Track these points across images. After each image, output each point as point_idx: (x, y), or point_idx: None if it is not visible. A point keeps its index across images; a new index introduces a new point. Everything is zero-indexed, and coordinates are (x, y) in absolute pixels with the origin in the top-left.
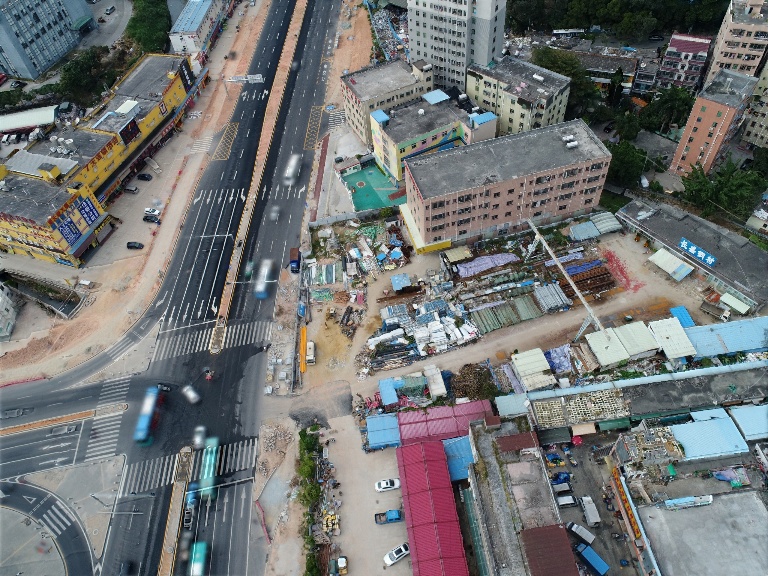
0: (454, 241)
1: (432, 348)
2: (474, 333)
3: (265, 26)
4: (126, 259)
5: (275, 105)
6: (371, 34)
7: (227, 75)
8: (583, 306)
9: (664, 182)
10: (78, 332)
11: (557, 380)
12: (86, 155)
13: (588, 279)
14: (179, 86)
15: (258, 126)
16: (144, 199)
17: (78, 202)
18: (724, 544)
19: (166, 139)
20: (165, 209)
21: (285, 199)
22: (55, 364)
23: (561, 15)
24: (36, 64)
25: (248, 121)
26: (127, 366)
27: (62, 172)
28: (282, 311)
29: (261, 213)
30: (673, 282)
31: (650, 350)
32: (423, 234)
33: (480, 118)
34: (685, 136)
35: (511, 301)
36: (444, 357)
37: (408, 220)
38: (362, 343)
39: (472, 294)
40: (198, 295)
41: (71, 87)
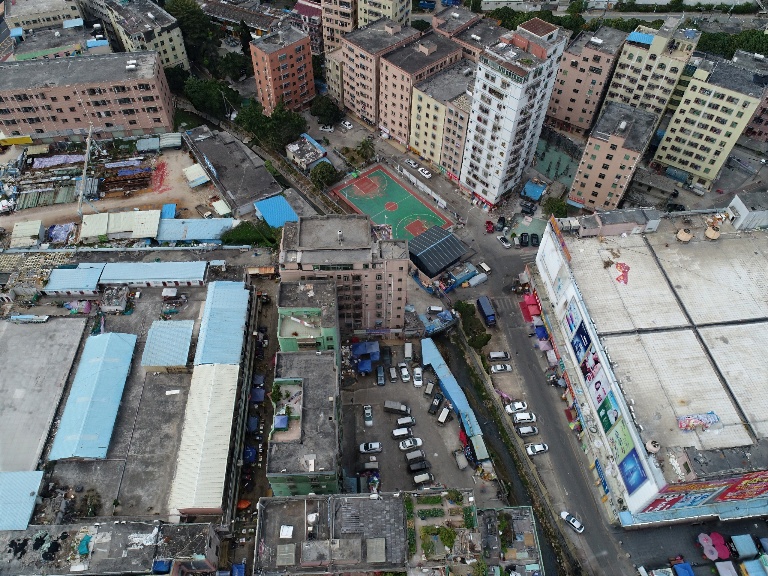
0: (35, 138)
1: None
2: (6, 207)
3: None
4: None
5: None
6: None
7: None
8: (111, 199)
9: None
10: None
11: (39, 244)
12: None
13: (129, 180)
14: None
15: None
16: None
17: None
18: (33, 347)
19: None
20: None
21: None
22: None
23: None
24: None
25: None
26: None
27: None
28: None
29: None
30: (194, 190)
31: (127, 231)
32: None
33: (93, 43)
34: (256, 79)
35: (57, 189)
36: None
37: None
38: None
39: (31, 181)
40: None
41: None
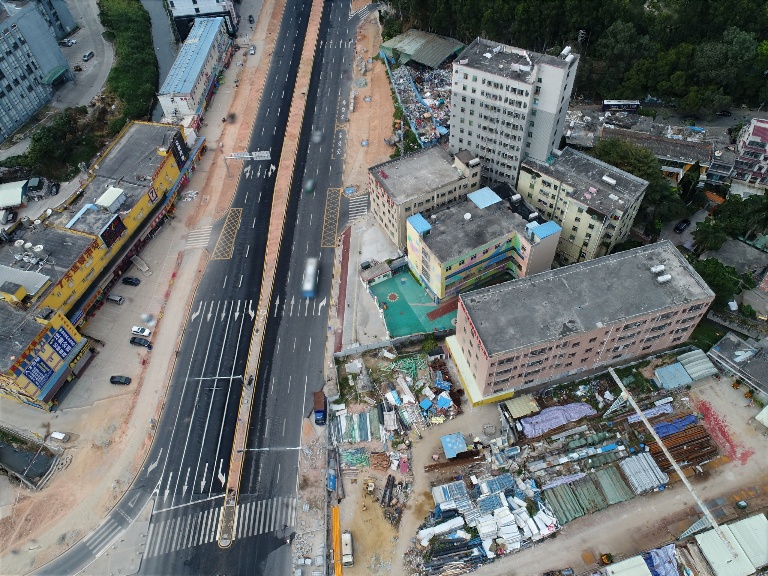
0: (517, 390)
1: (501, 547)
2: (553, 526)
3: (268, 80)
4: (109, 399)
5: (284, 186)
6: (391, 96)
7: (226, 144)
8: (682, 483)
9: (754, 303)
10: (49, 510)
11: None
12: (59, 265)
13: (684, 444)
14: (171, 165)
15: (265, 213)
16: (131, 312)
17: (49, 335)
18: None
19: (156, 229)
20: (157, 327)
21: (303, 316)
22: (19, 561)
23: (614, 85)
24: (0, 127)
25: (253, 206)
26: (112, 565)
27: (29, 292)
28: (307, 483)
29: (274, 336)
30: None
31: None
32: (482, 387)
33: (541, 230)
34: None
35: (593, 475)
36: (517, 559)
37: (459, 360)
38: (411, 534)
39: (543, 463)
40: (201, 456)
41: (42, 160)
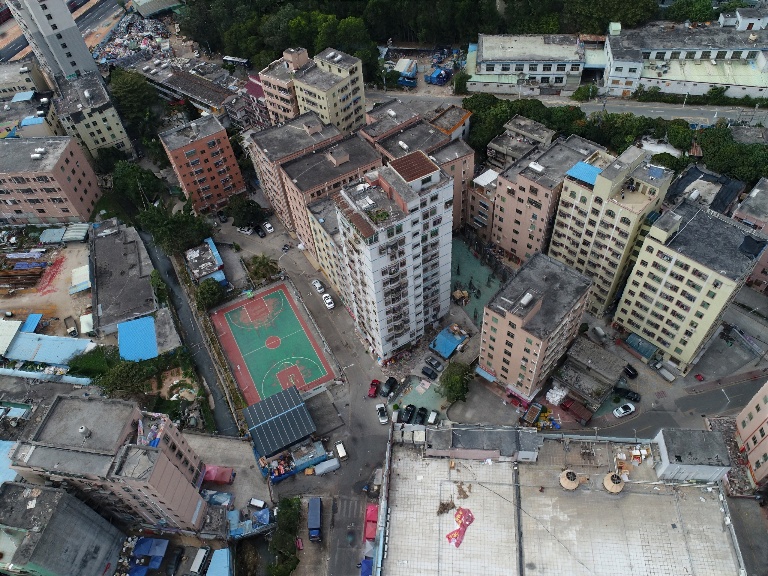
0: None
1: None
2: None
3: None
4: None
5: None
6: None
7: None
8: None
9: (174, 210)
10: None
11: None
12: None
13: (19, 276)
14: None
15: None
16: None
17: None
18: None
19: None
20: None
21: None
22: None
23: None
24: None
25: None
26: None
27: None
28: None
29: None
30: (76, 295)
31: None
32: None
33: (28, 121)
34: (174, 170)
35: None
36: None
37: None
38: None
39: None
40: None
41: None
